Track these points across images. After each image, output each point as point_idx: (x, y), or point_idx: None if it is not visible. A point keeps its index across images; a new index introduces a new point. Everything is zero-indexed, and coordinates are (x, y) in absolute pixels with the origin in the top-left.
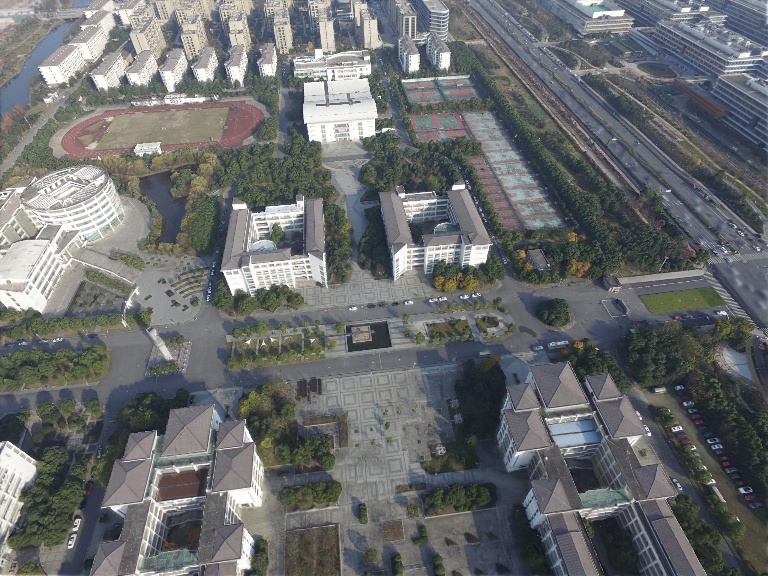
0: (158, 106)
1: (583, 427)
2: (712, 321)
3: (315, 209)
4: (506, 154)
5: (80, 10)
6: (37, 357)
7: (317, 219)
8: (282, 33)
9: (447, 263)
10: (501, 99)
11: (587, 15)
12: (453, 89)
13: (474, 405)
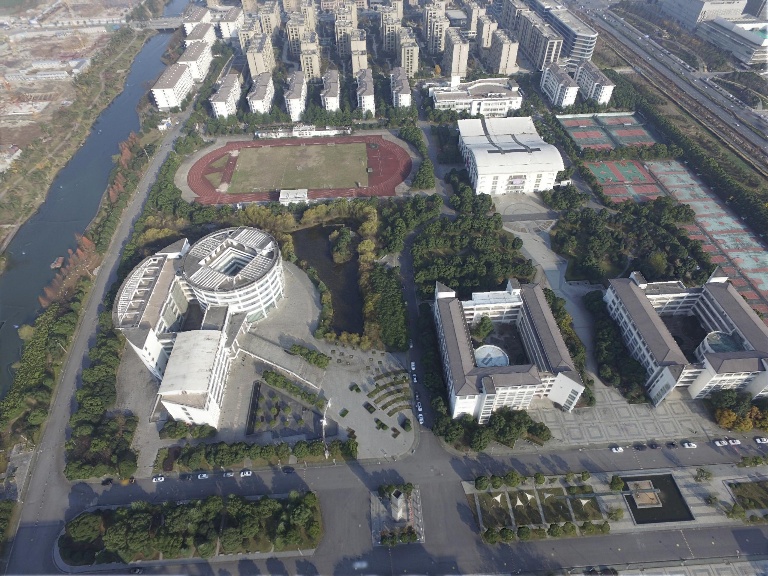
0: (285, 139)
1: None
2: None
3: (539, 301)
4: (723, 221)
5: (173, 20)
6: (235, 510)
7: (547, 317)
8: (410, 55)
9: (728, 388)
10: (693, 147)
11: (753, 42)
12: (620, 129)
13: None
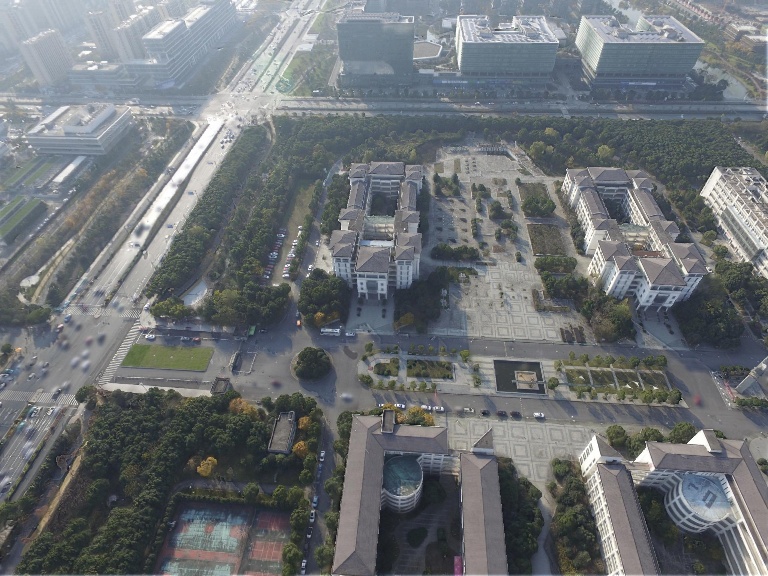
0: None
1: None
2: (168, 332)
3: None
4: None
5: None
6: None
7: (633, 554)
8: None
9: None
10: None
11: None
12: None
13: (428, 299)
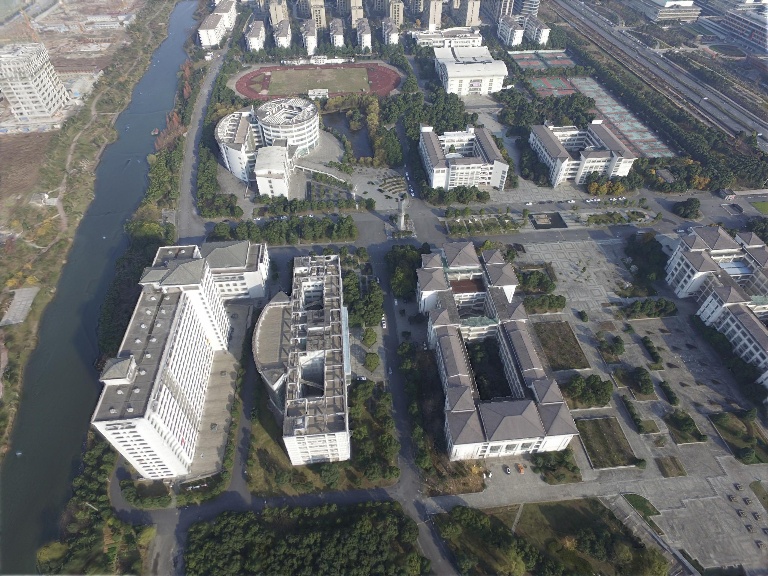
0: (304, 65)
1: (737, 265)
2: None
3: (486, 134)
4: (615, 108)
5: None
6: (308, 221)
7: (490, 140)
8: (397, 10)
9: None
10: (602, 67)
11: (659, 4)
12: (554, 60)
13: (643, 261)
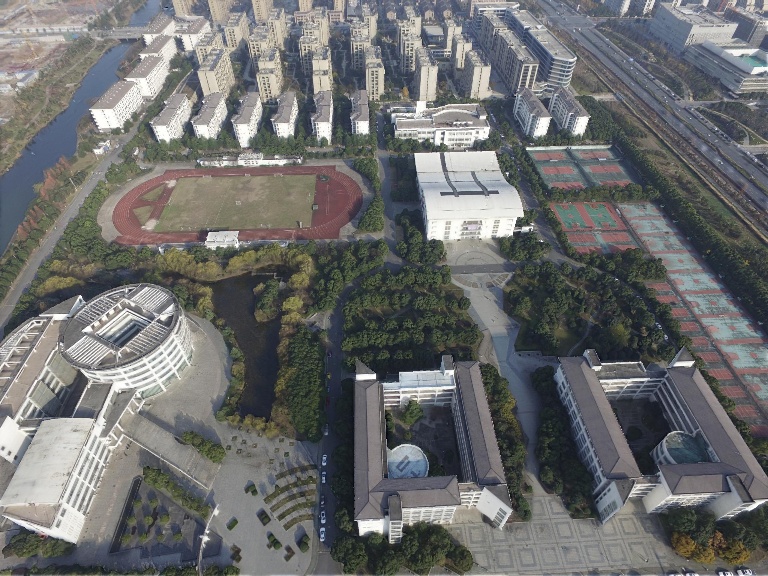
0: (229, 167)
1: None
2: None
3: (474, 387)
4: (698, 278)
5: (137, 29)
6: None
7: (481, 408)
8: (375, 77)
9: (688, 504)
10: (670, 189)
11: (742, 70)
12: (594, 164)
13: None
